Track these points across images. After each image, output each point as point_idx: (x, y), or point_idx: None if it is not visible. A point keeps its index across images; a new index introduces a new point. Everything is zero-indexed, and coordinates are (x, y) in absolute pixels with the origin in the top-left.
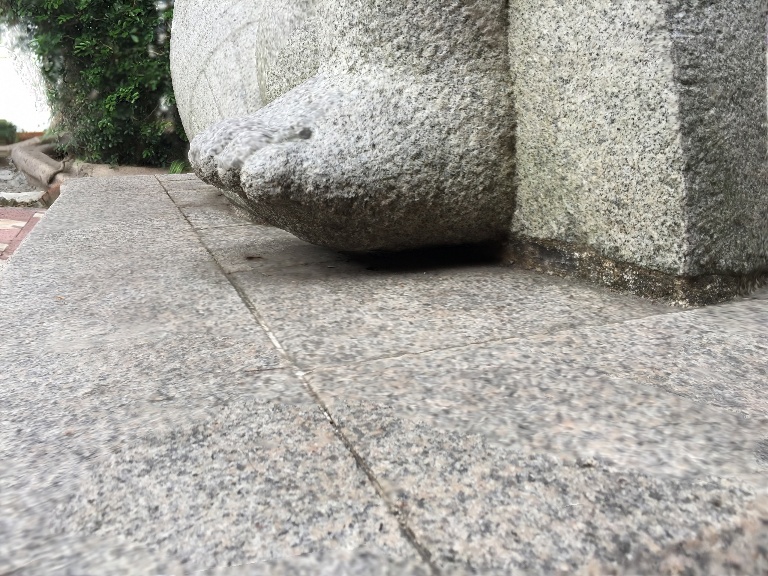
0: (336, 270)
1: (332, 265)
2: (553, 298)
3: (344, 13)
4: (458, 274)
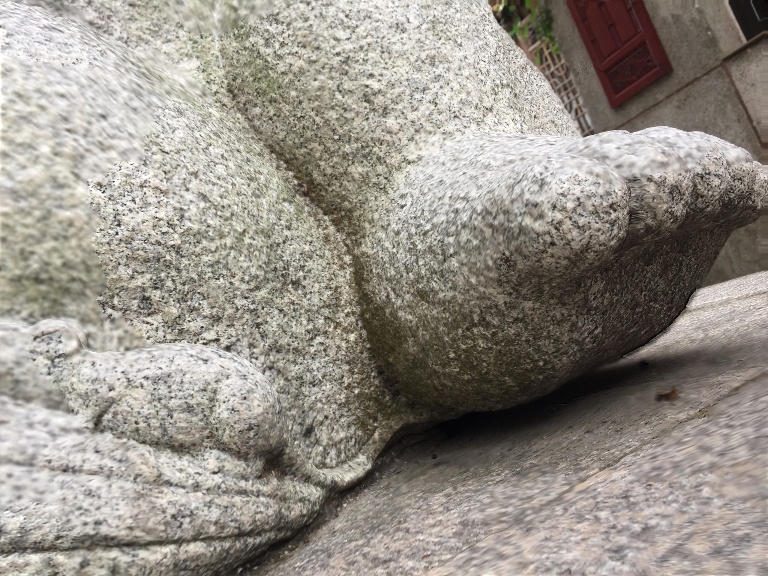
0: (666, 367)
1: (637, 381)
2: (682, 321)
3: (491, 69)
4: (628, 354)
